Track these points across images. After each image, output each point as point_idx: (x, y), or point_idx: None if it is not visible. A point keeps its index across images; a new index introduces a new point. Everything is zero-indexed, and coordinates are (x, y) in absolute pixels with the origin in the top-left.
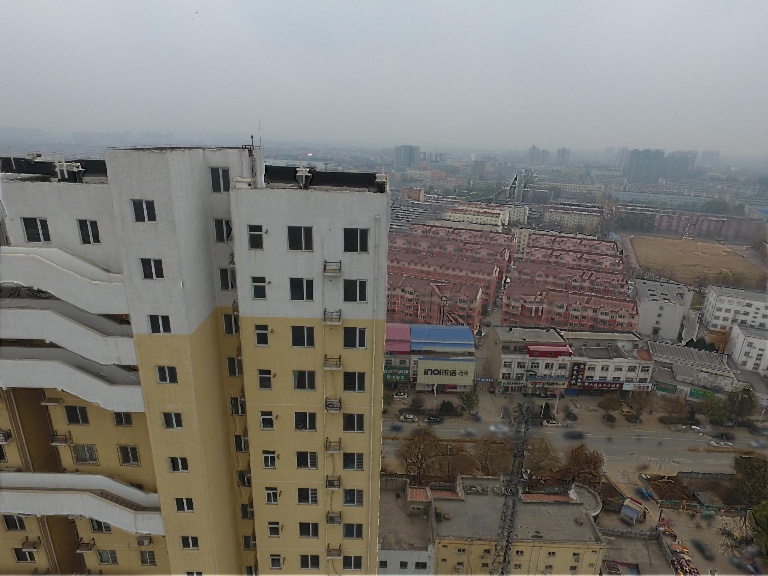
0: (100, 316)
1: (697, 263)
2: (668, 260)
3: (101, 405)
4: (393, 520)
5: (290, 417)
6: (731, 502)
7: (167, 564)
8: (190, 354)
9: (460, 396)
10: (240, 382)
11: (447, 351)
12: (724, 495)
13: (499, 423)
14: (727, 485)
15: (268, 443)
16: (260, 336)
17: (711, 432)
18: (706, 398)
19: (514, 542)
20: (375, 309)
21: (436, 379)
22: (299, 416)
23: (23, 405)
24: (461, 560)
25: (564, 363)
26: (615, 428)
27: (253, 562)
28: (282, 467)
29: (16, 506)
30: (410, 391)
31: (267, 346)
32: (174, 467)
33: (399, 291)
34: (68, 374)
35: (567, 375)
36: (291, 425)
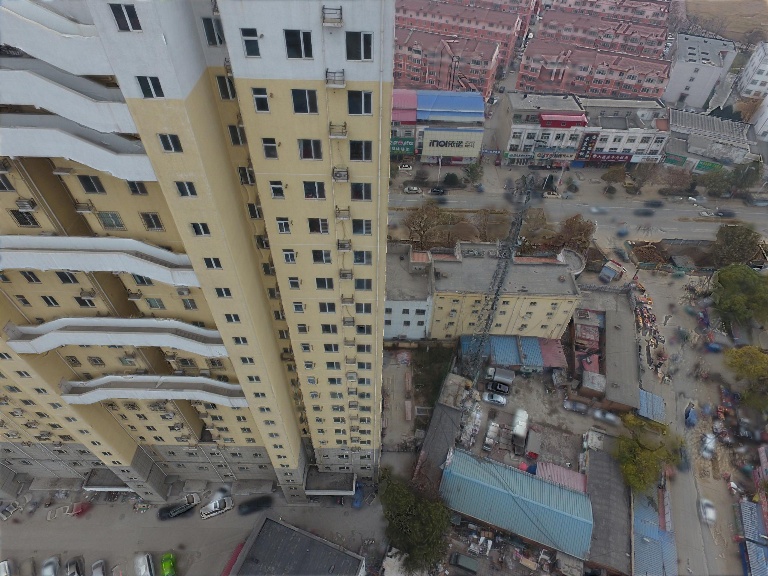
0: (83, 78)
1: (756, 12)
2: (723, 8)
3: (113, 174)
4: (397, 278)
5: (299, 186)
6: (703, 264)
7: (207, 309)
8: (190, 121)
9: (465, 168)
10: (245, 151)
11: (455, 121)
12: (698, 258)
13: (501, 195)
14: (704, 250)
15: (281, 211)
16: (259, 101)
17: (706, 203)
18: (712, 170)
19: (502, 295)
20: (382, 69)
21: (442, 151)
22: (308, 185)
23: (36, 175)
24: (455, 308)
25: (576, 134)
26: (613, 199)
27: (279, 308)
28: (296, 232)
29: (64, 264)
30: (415, 163)
31: (268, 112)
32: (197, 231)
33: (405, 50)
34: (70, 143)
35: (577, 147)
36: (301, 194)
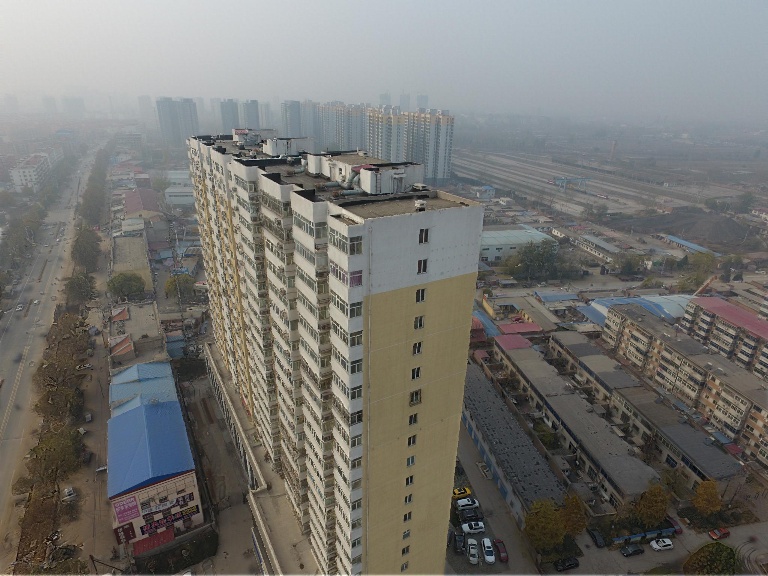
0: None
1: None
2: None
3: None
4: (142, 360)
5: None
6: (73, 313)
7: None
8: None
9: None
10: None
11: None
12: None
13: None
14: (63, 309)
15: None
16: None
17: (5, 309)
18: None
19: None
20: None
21: None
22: None
23: None
24: None
25: None
26: None
27: None
28: None
29: None
30: None
31: None
32: None
33: None
34: None
35: None
36: None
